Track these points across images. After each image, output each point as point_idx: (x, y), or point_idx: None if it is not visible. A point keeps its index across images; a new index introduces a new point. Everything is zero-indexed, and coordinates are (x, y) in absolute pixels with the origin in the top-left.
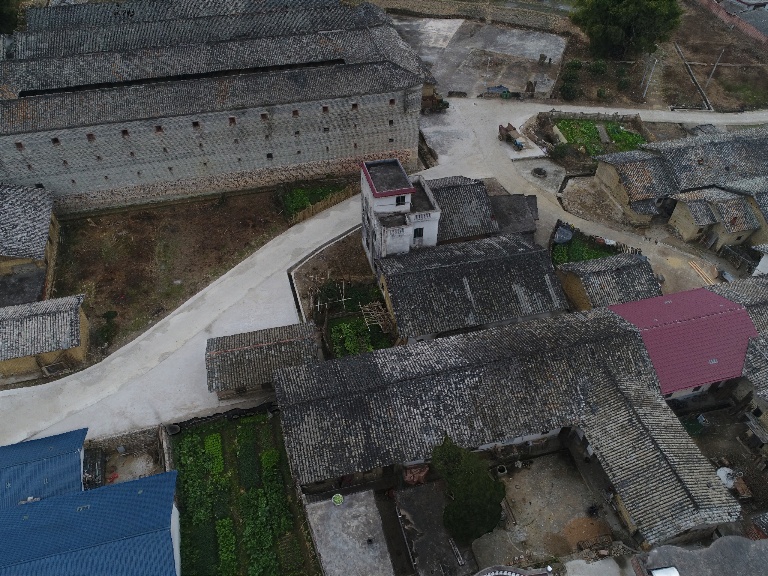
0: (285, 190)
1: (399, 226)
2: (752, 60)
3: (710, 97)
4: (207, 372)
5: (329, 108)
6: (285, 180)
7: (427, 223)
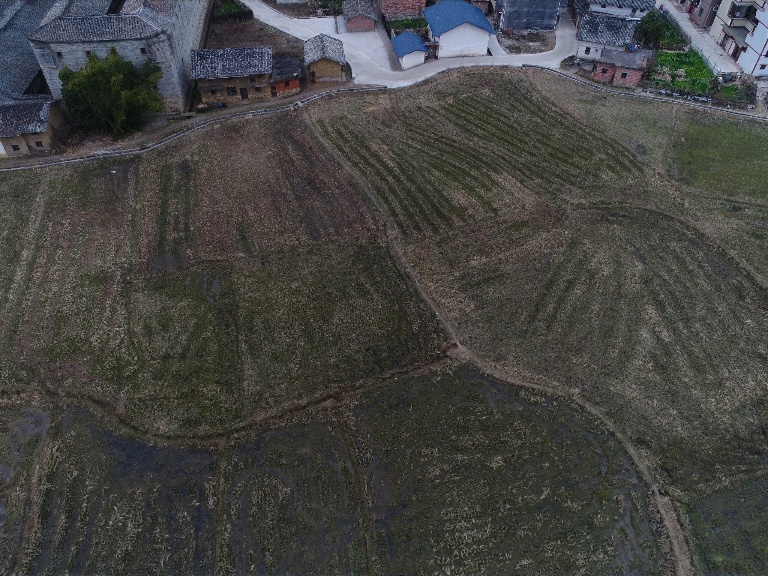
0: None
1: None
2: None
3: None
4: None
5: None
6: None
7: None
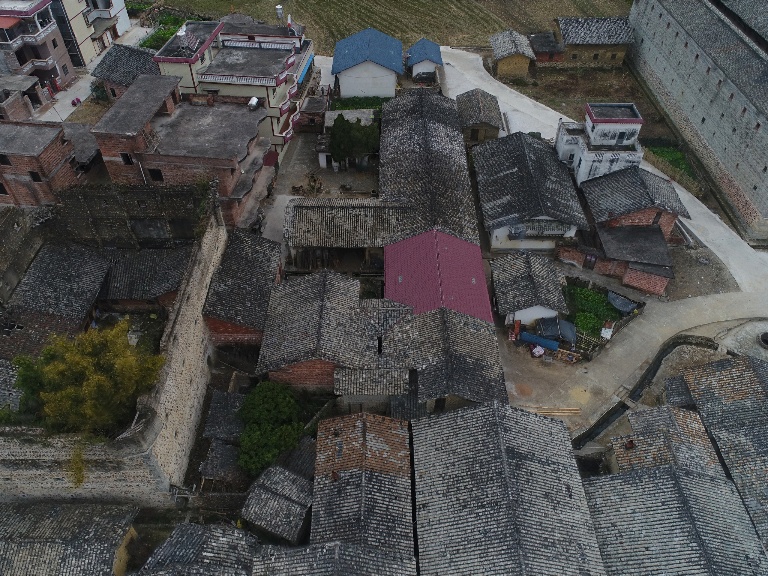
0: None
1: None
2: None
3: None
4: None
5: (747, 112)
6: (697, 151)
7: None
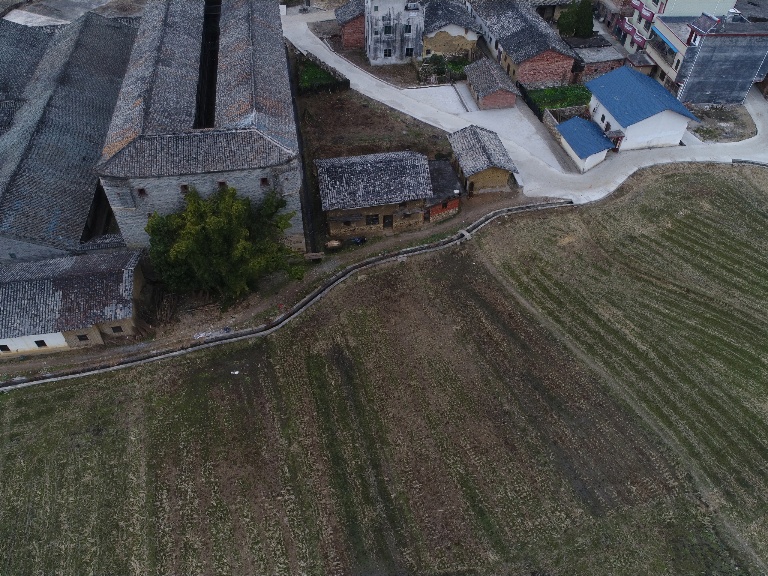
0: None
1: (420, 5)
2: None
3: None
4: (511, 91)
5: None
6: None
7: None
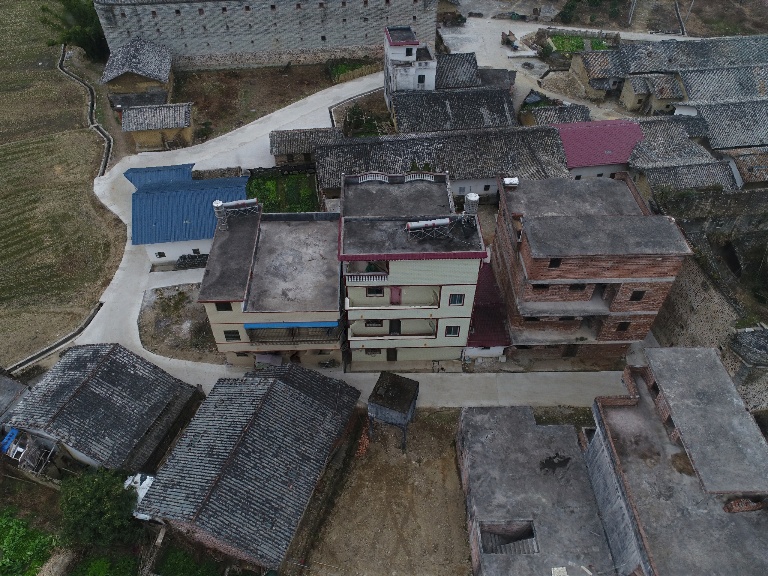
0: (333, 64)
1: (406, 67)
2: (736, 4)
3: (687, 26)
4: (270, 143)
5: (369, 2)
6: None
7: (427, 71)
